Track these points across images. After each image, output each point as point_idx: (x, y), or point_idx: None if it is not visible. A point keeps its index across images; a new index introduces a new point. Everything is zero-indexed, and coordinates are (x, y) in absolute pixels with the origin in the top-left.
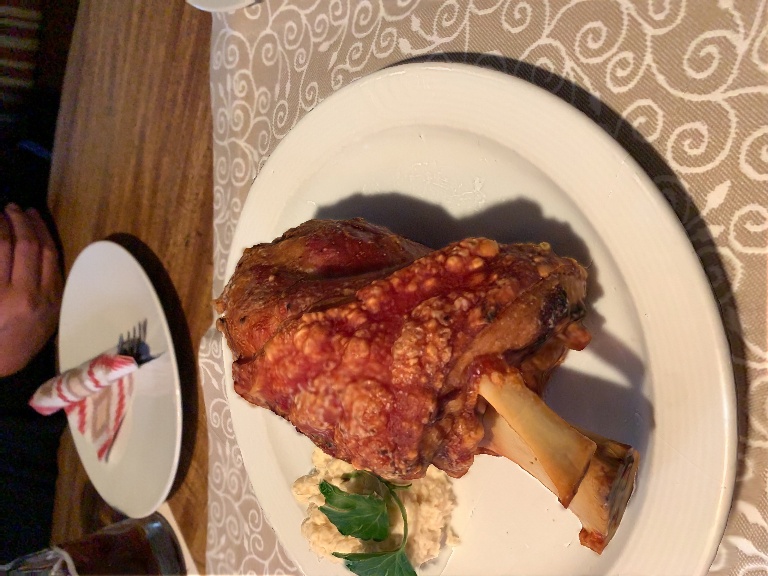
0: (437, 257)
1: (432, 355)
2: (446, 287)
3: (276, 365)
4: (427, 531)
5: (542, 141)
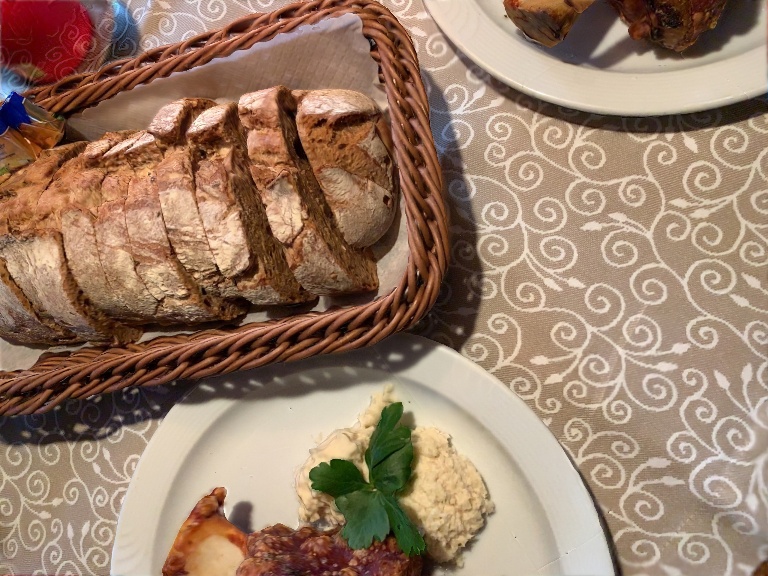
0: None
1: None
2: None
3: None
4: None
5: None
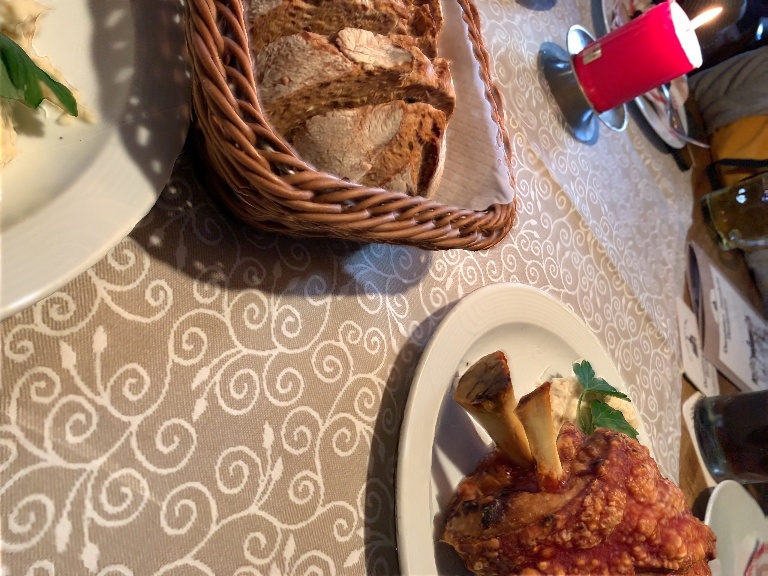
0: None
1: (599, 504)
2: (571, 554)
3: (697, 539)
4: (560, 396)
5: None
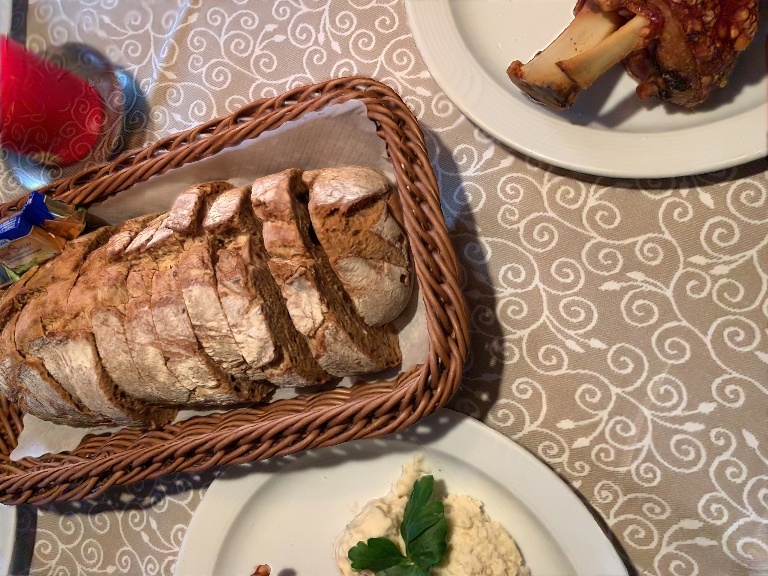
0: (754, 1)
1: None
2: (727, 5)
3: None
4: None
5: None
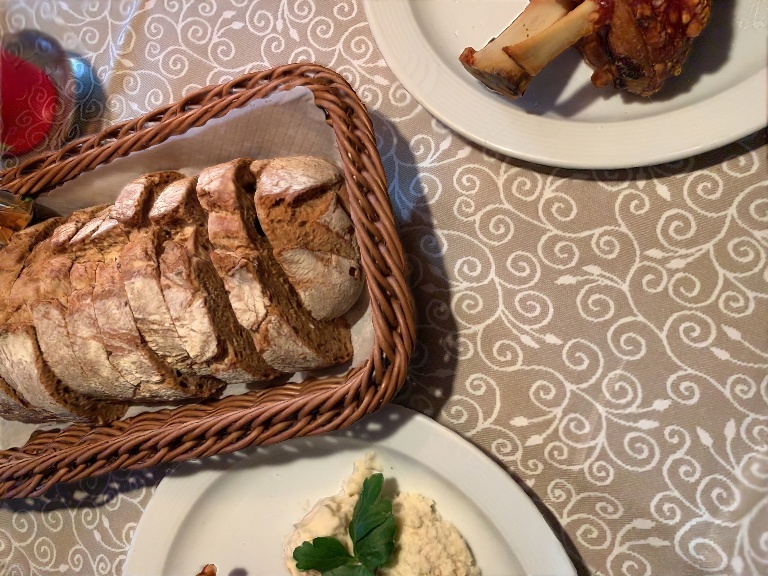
0: None
1: None
2: None
3: None
4: None
5: (764, 89)
